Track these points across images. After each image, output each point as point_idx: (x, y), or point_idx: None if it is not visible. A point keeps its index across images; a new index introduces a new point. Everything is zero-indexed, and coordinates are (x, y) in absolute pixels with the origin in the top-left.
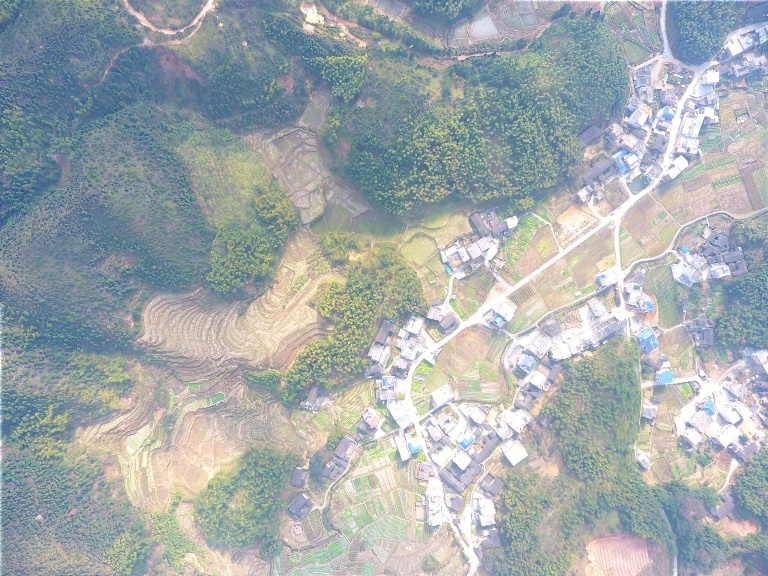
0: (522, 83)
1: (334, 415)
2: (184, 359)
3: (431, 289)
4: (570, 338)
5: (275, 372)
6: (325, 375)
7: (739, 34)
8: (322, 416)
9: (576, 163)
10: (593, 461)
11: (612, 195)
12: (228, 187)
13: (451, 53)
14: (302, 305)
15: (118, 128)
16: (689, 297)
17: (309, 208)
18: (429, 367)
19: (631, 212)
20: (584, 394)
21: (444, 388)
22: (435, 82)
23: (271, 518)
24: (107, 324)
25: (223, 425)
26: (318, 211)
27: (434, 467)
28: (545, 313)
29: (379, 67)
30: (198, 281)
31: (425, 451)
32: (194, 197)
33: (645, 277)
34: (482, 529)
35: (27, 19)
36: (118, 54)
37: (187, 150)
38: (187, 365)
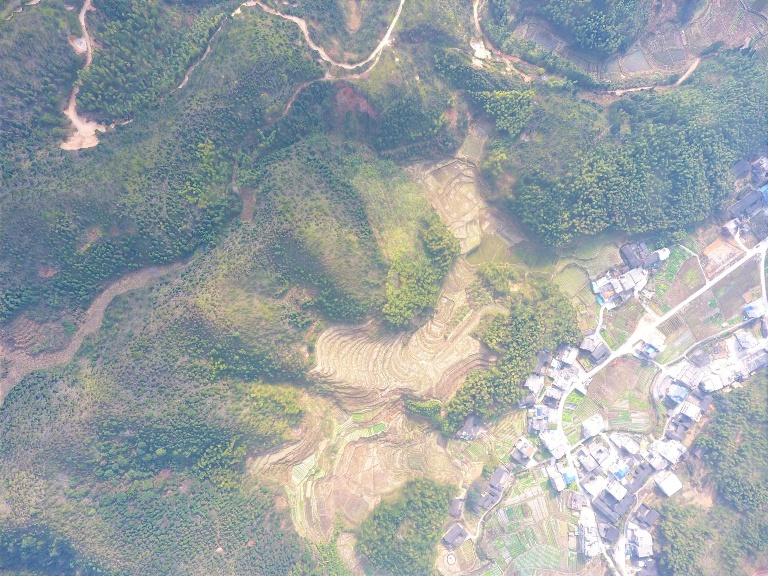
0: (690, 120)
1: (488, 444)
2: (352, 389)
3: (582, 319)
4: (720, 369)
5: (437, 402)
6: (486, 405)
7: None
8: (476, 445)
9: (728, 197)
10: (753, 493)
11: (758, 228)
12: (397, 219)
13: (609, 88)
14: (465, 336)
15: (301, 161)
16: None
17: (466, 238)
18: (580, 397)
19: None
20: (743, 426)
21: (597, 418)
22: (602, 117)
23: (432, 548)
24: (286, 355)
25: (382, 454)
26: (475, 242)
27: (586, 497)
28: (693, 344)
29: (545, 102)
30: (372, 313)
31: (577, 481)
32: (371, 230)
33: None
34: (637, 560)
35: (222, 54)
36: (300, 88)
37: (361, 182)
38: (354, 395)
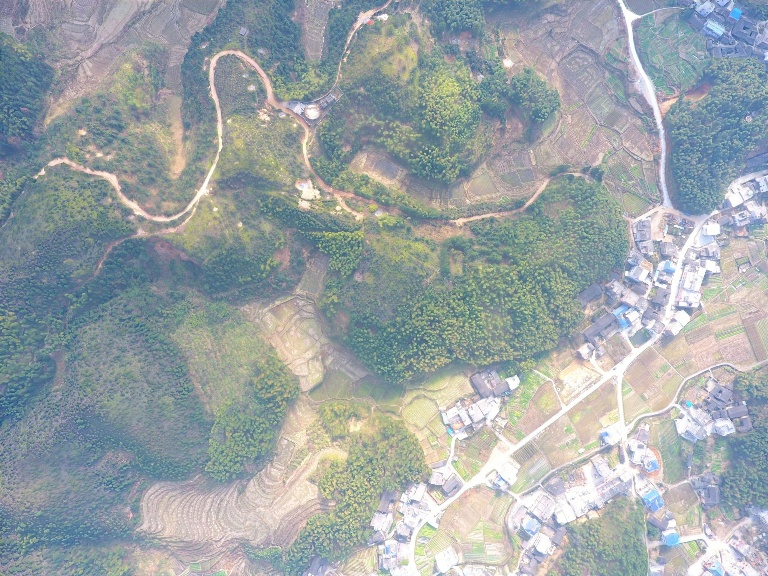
0: (521, 259)
1: None
2: (184, 543)
3: (433, 451)
4: (574, 499)
5: (277, 549)
6: (327, 550)
7: (739, 183)
8: None
9: (577, 324)
10: None
11: (614, 350)
12: (226, 367)
13: (449, 218)
14: (303, 481)
15: (113, 323)
16: (694, 453)
17: (308, 376)
18: (432, 530)
19: (633, 366)
20: (590, 565)
21: (448, 554)
22: (433, 257)
23: None
24: (105, 520)
25: None
26: (317, 378)
27: None
28: (548, 471)
29: (376, 241)
30: (197, 470)
31: None
32: (191, 387)
33: (649, 434)
34: None
35: (19, 225)
36: (112, 246)
37: (183, 335)
38: (187, 548)
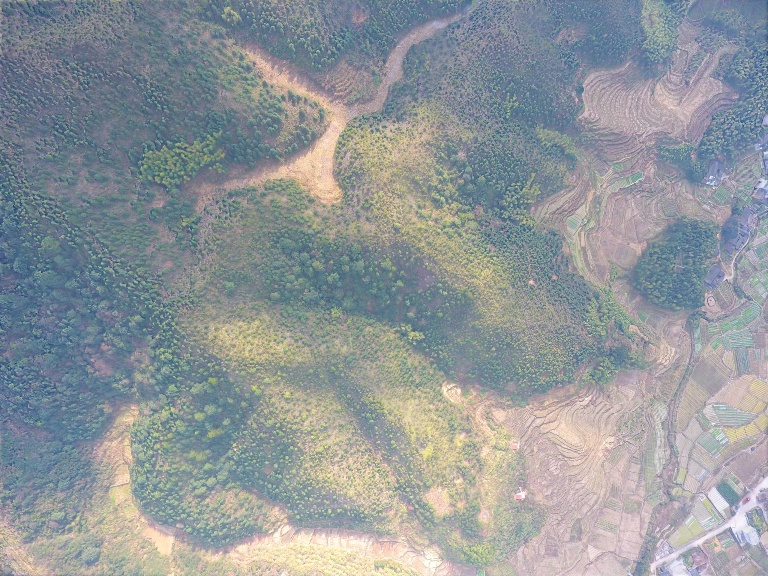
0: None
1: (732, 188)
2: (614, 136)
3: None
4: None
5: (689, 144)
6: (734, 143)
7: None
8: (721, 191)
9: None
10: None
11: None
12: None
13: None
14: (707, 78)
15: None
16: None
17: None
18: None
19: None
20: None
21: None
22: None
23: (702, 283)
24: (562, 98)
25: (639, 205)
26: None
27: None
28: None
29: None
30: (632, 53)
31: None
32: None
33: None
34: None
35: None
36: None
37: None
38: (616, 142)
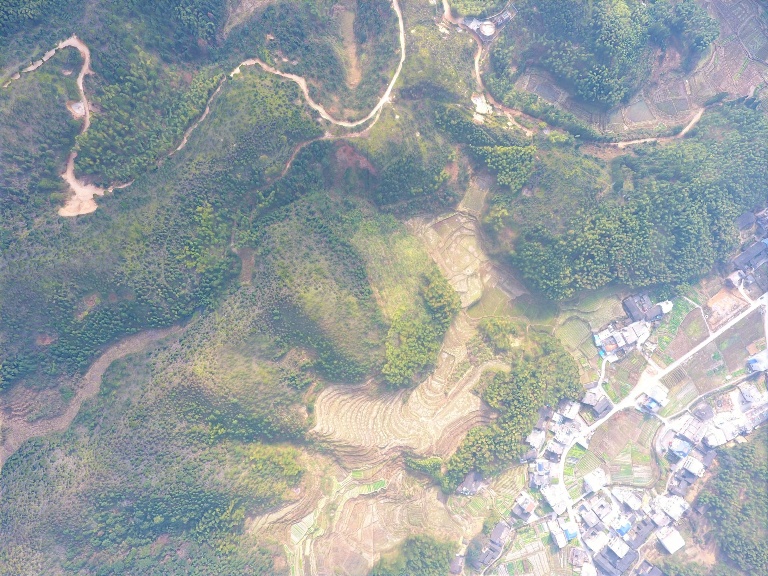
0: (693, 177)
1: (489, 500)
2: (351, 448)
3: (584, 372)
4: (723, 423)
5: (438, 459)
6: (487, 462)
7: None
8: (477, 500)
9: (733, 250)
10: (757, 553)
11: (762, 279)
12: (397, 276)
13: (611, 140)
14: (465, 392)
15: (300, 222)
16: None
17: (467, 292)
18: (581, 451)
19: None
20: (746, 484)
21: (599, 473)
22: (604, 173)
23: None
24: (284, 417)
25: (382, 511)
26: (476, 295)
27: (588, 553)
28: (696, 397)
29: (547, 157)
30: (372, 373)
31: (578, 536)
32: (371, 289)
33: None
34: None
35: (221, 117)
36: (300, 147)
37: (361, 240)
38: (354, 454)
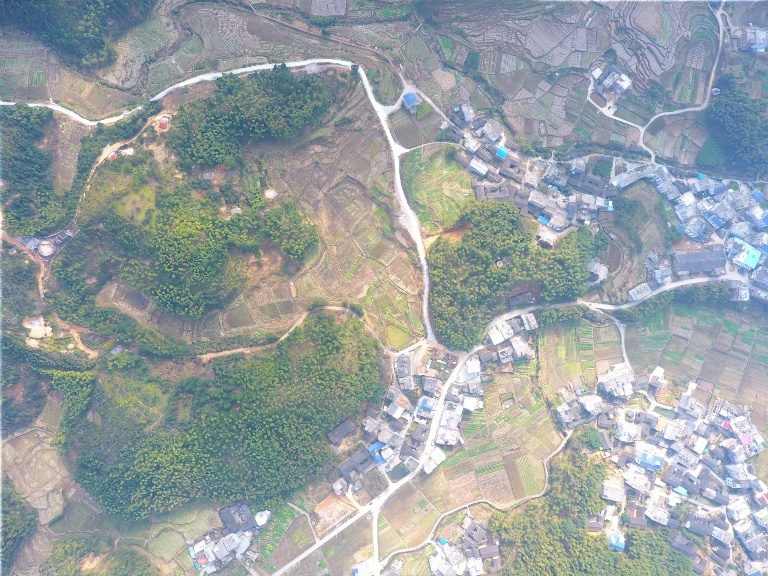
0: (248, 408)
1: None
2: None
3: None
4: None
5: None
6: None
7: (504, 320)
8: None
9: (325, 463)
10: None
11: (370, 485)
12: None
13: (194, 354)
14: None
15: None
16: None
17: (47, 508)
18: None
19: (391, 501)
20: None
21: None
22: (163, 401)
23: None
24: None
25: None
26: (57, 512)
27: None
28: None
29: (107, 382)
30: None
31: None
32: None
33: (399, 572)
34: None
35: None
36: None
37: None
38: None
